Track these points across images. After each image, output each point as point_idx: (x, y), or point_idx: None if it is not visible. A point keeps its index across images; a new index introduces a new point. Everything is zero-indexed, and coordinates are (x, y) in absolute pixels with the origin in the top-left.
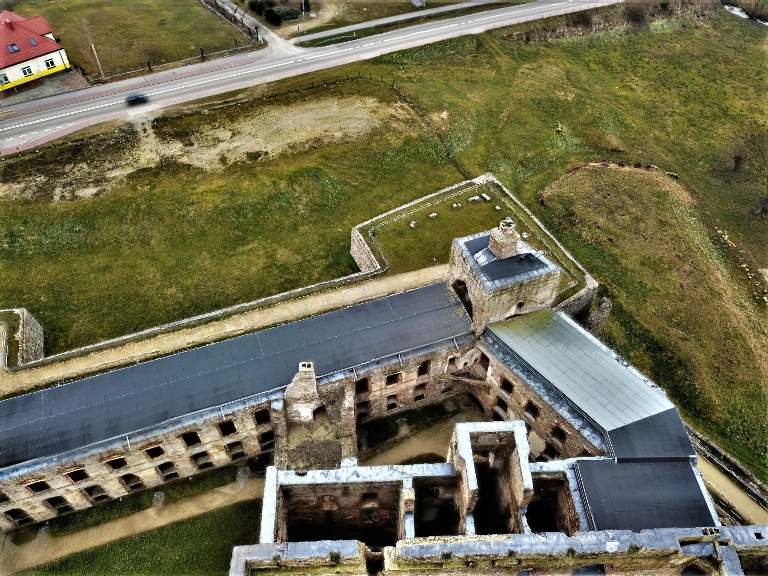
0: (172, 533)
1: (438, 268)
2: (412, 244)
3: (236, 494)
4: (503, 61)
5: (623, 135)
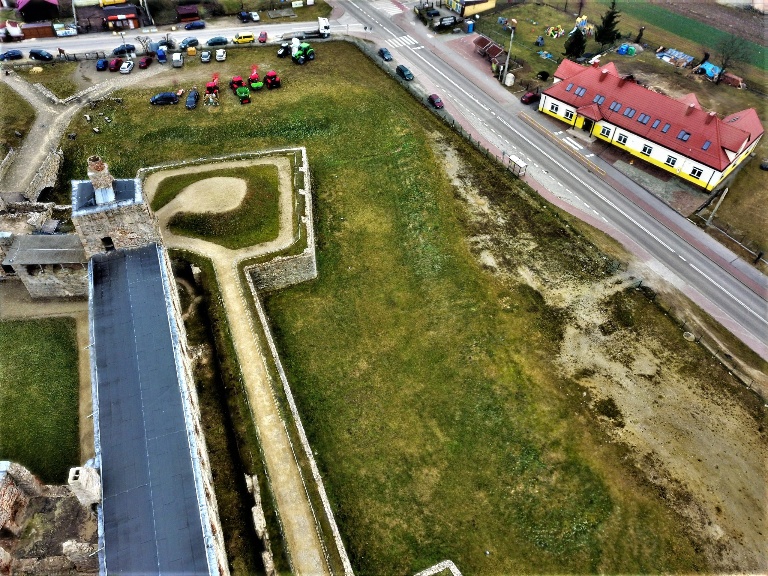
0: (69, 417)
1: None
2: None
3: None
4: None
5: None
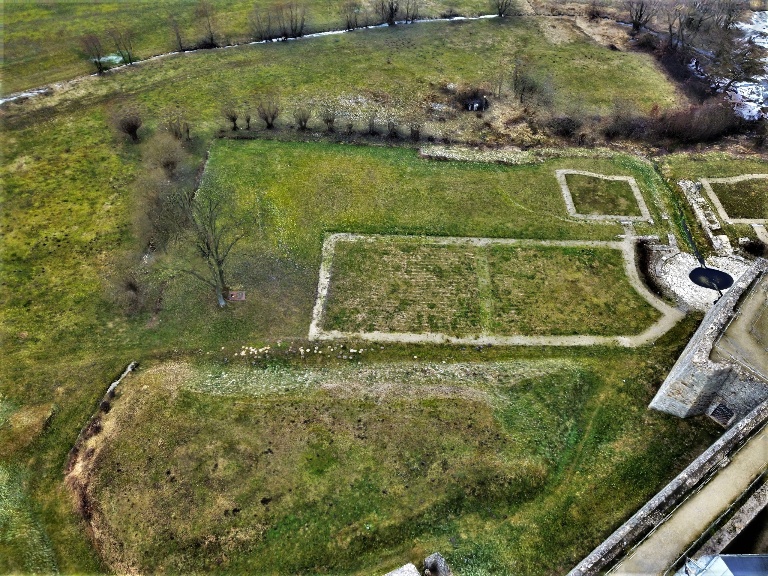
0: None
1: None
2: None
3: None
4: None
5: (13, 400)
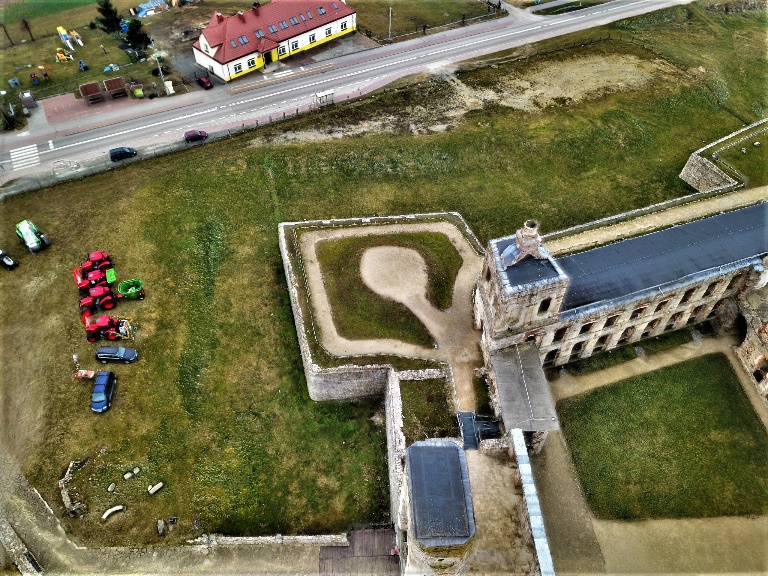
0: (667, 375)
1: None
2: (752, 165)
3: (700, 349)
4: (716, 28)
5: None
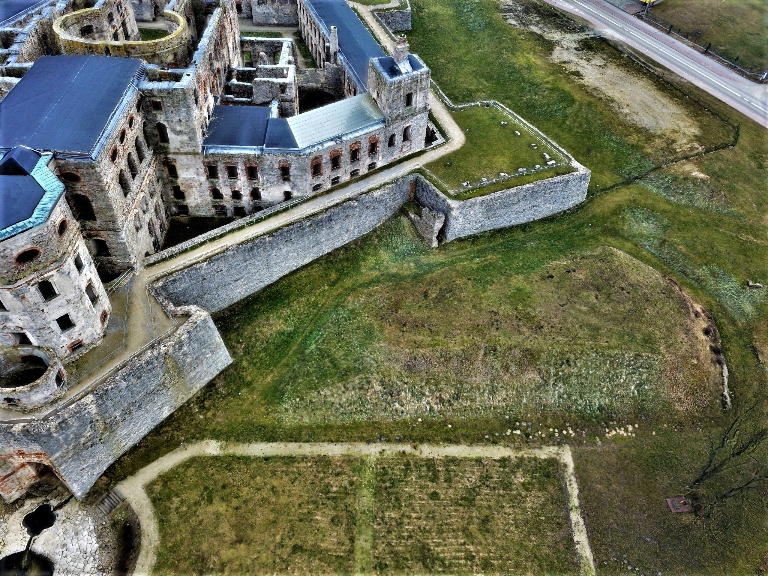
0: None
1: (459, 132)
2: (482, 122)
3: None
4: None
5: None
